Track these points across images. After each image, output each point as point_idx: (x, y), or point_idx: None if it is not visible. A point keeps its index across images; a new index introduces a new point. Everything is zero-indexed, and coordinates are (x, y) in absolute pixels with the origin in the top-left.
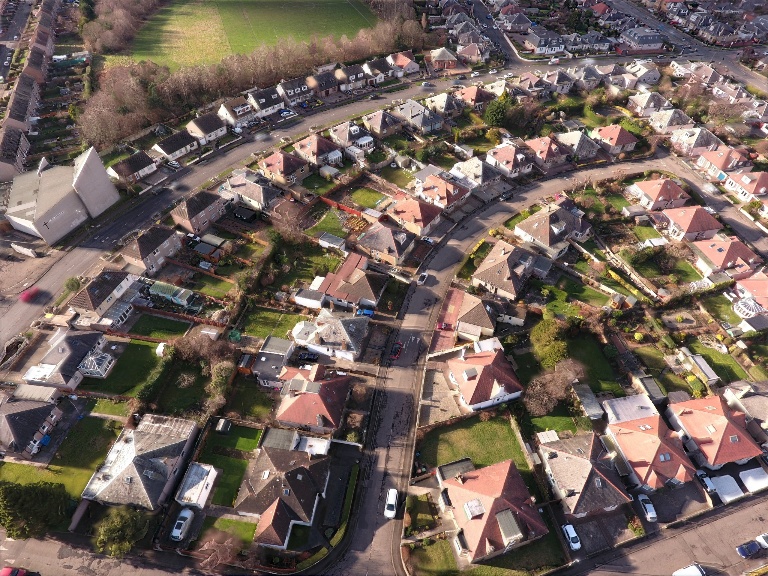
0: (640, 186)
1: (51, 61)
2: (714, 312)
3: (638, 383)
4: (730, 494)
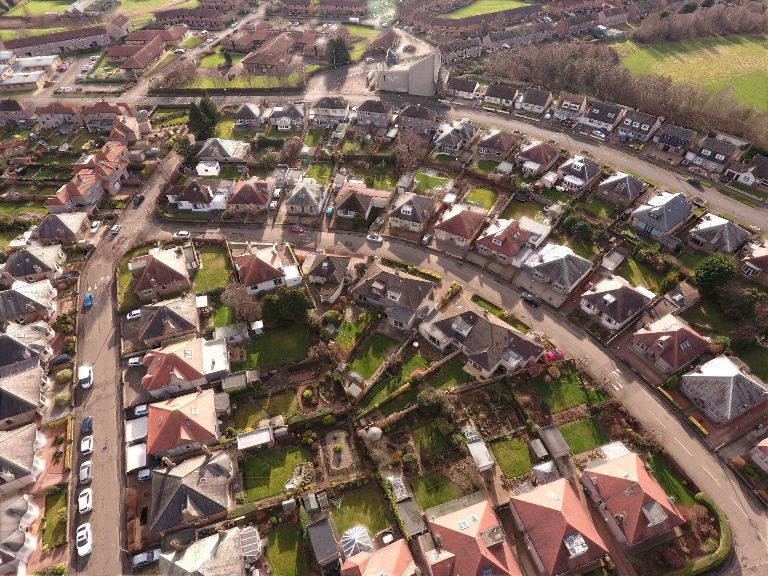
0: (624, 456)
1: (595, 28)
2: (354, 500)
3: None
4: (131, 429)
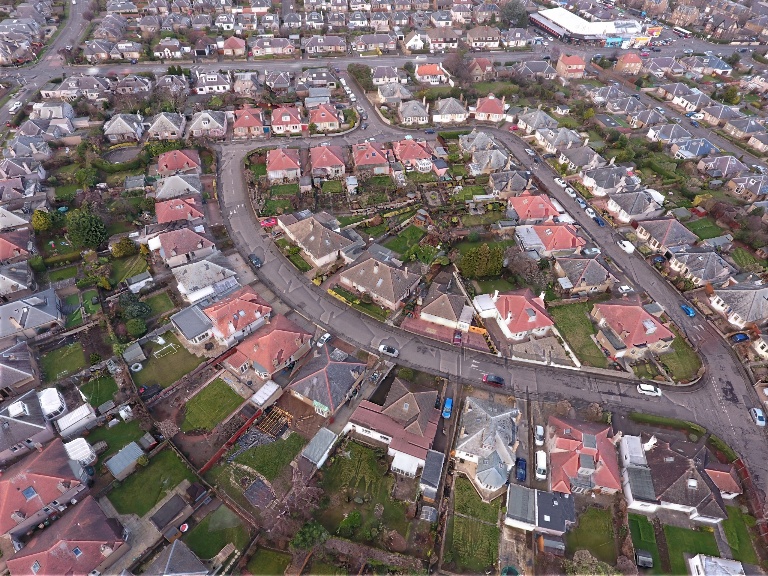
0: (275, 169)
1: None
2: None
3: (504, 229)
4: (568, 218)
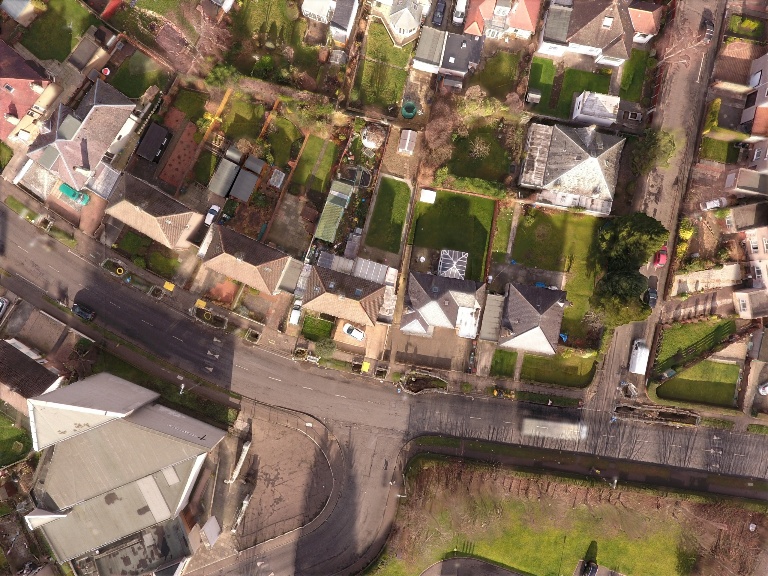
0: None
1: None
2: None
3: None
4: None
